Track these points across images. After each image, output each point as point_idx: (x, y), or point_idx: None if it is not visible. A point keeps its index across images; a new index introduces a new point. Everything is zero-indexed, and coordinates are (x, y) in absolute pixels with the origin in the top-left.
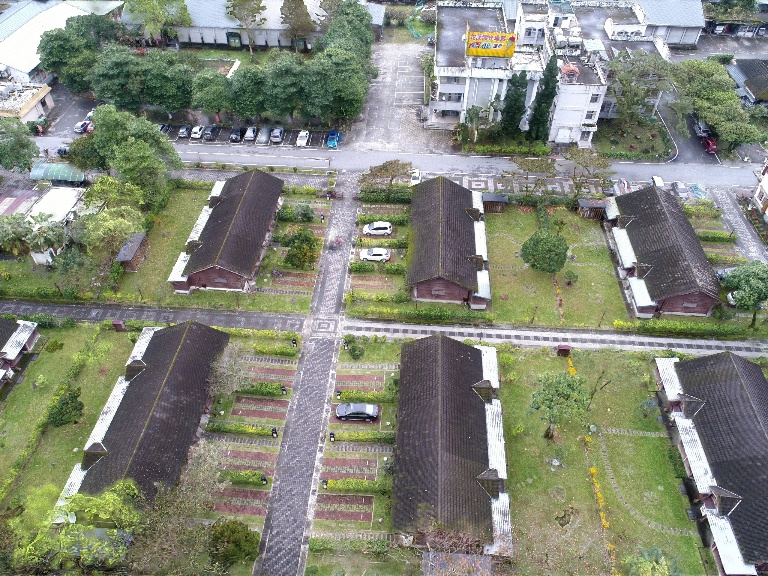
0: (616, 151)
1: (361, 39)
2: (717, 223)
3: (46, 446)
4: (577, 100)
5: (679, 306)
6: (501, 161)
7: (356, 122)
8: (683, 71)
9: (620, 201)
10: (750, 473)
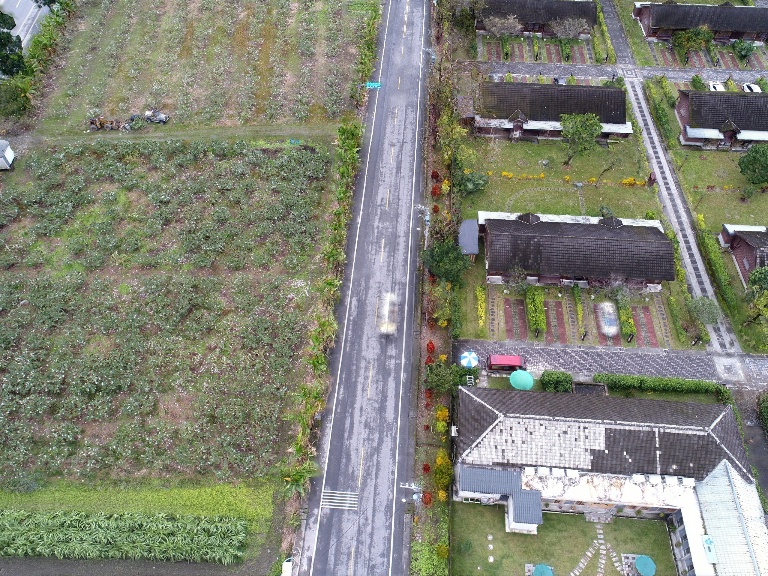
0: None
1: None
2: None
3: None
4: None
5: (742, 258)
6: None
7: None
8: None
9: None
10: (551, 229)
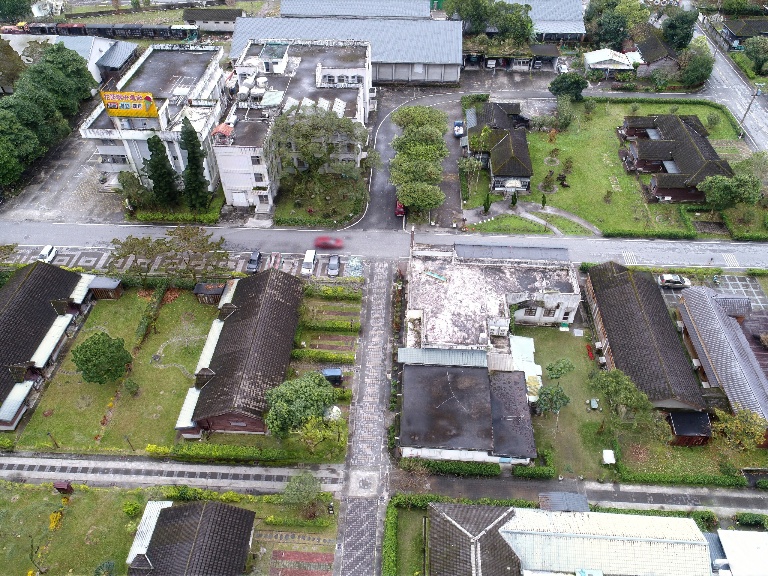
0: (295, 216)
1: (54, 90)
2: (355, 307)
3: None
4: (238, 162)
5: (228, 425)
6: (160, 231)
7: (31, 185)
8: (396, 120)
9: (238, 286)
10: None
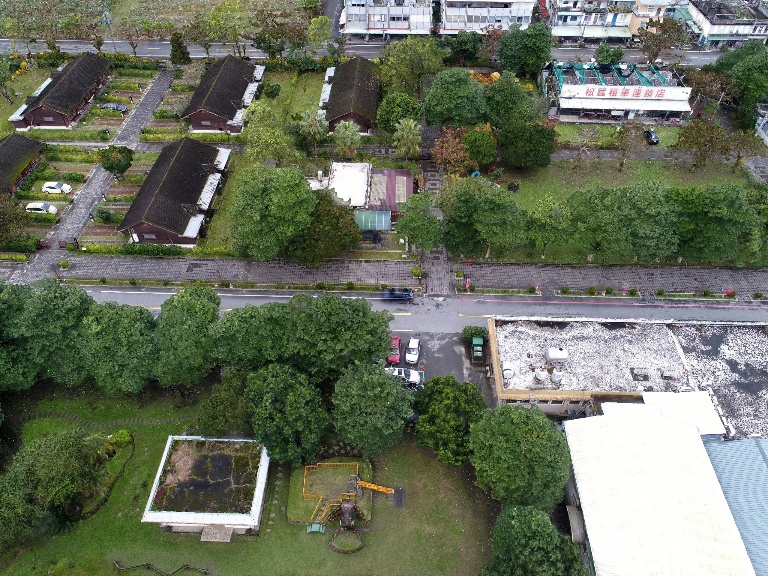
0: None
1: None
2: None
3: (286, 96)
4: None
5: None
6: None
7: None
8: None
9: None
10: None
